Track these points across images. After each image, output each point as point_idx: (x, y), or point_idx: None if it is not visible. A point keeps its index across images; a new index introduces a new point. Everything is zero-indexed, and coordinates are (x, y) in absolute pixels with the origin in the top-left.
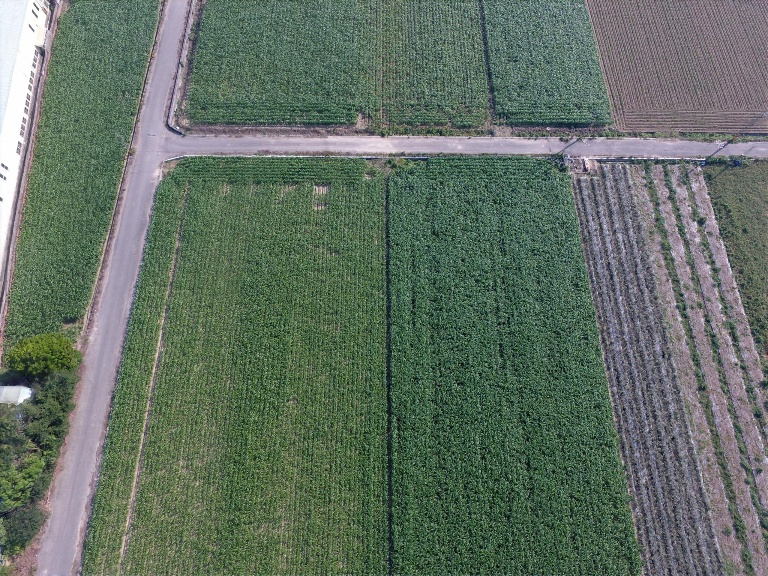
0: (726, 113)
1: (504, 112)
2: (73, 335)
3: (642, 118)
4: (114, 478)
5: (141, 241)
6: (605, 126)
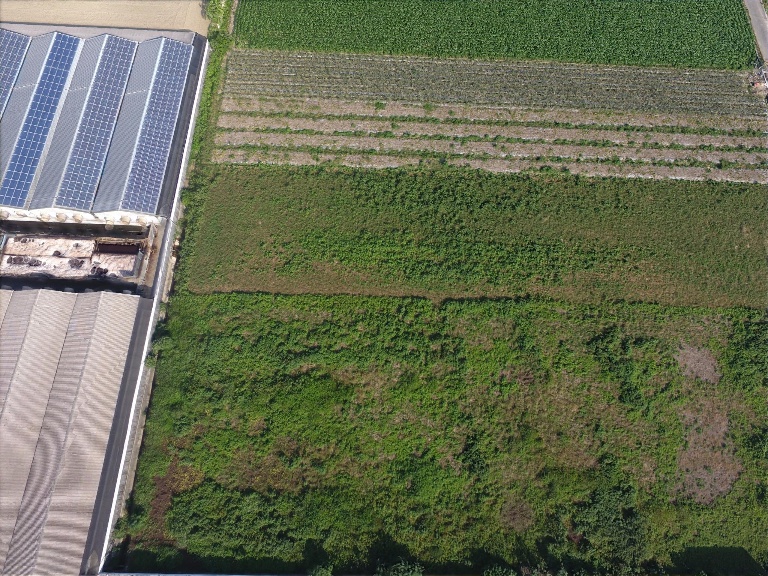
0: None
1: None
2: None
3: None
4: None
5: None
6: None
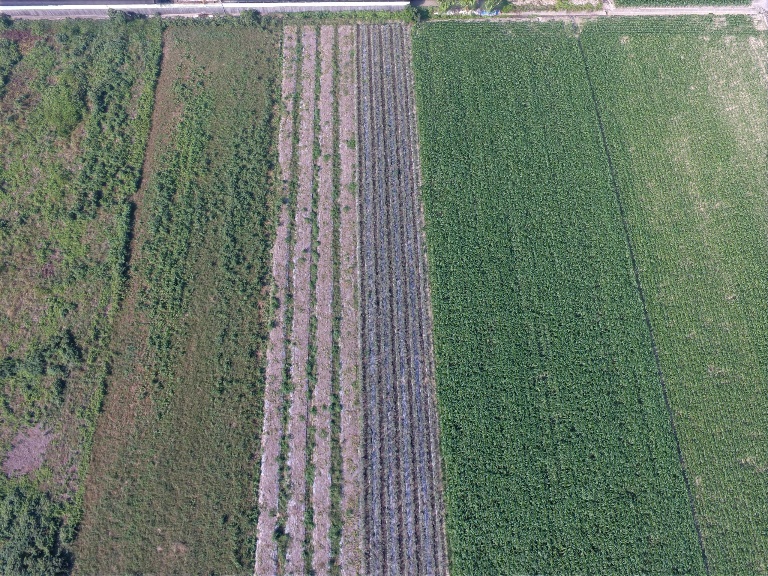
0: None
1: None
2: None
3: None
4: None
5: None
6: None
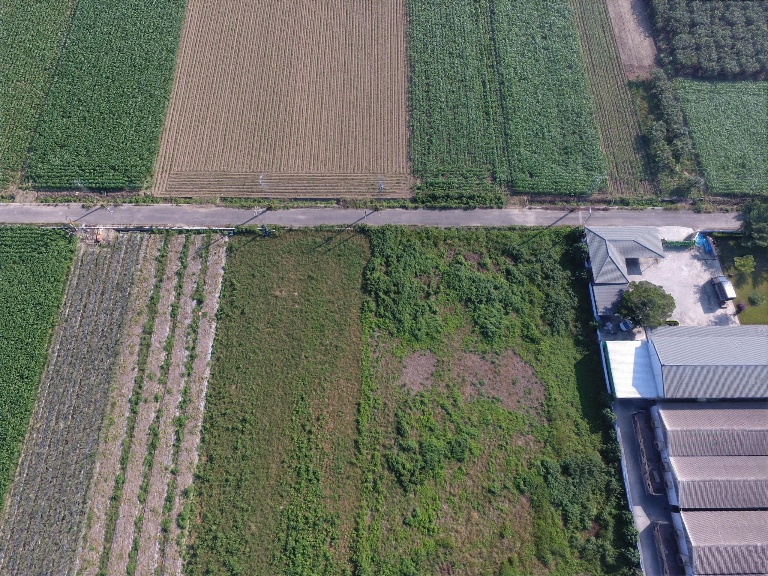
0: (282, 175)
1: (31, 175)
2: None
3: (187, 181)
4: None
5: None
6: (141, 190)
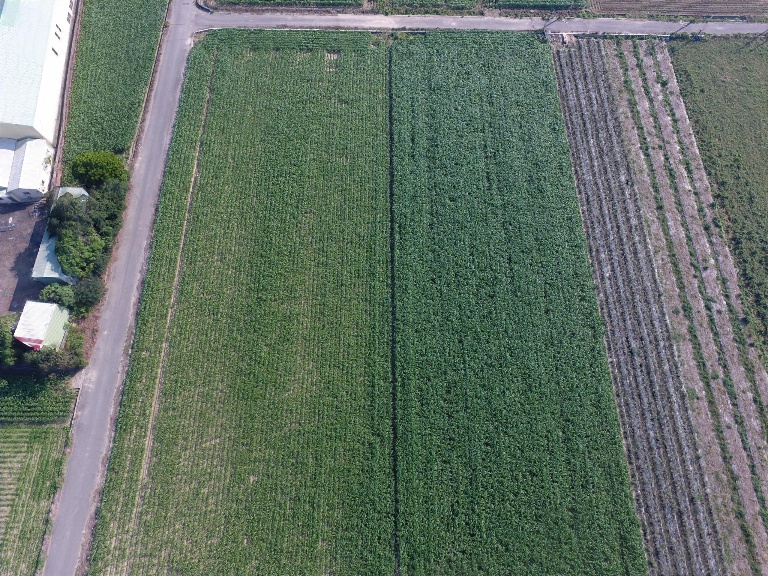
0: None
1: None
2: (121, 161)
3: (615, 3)
4: (160, 266)
5: (177, 93)
6: (582, 9)
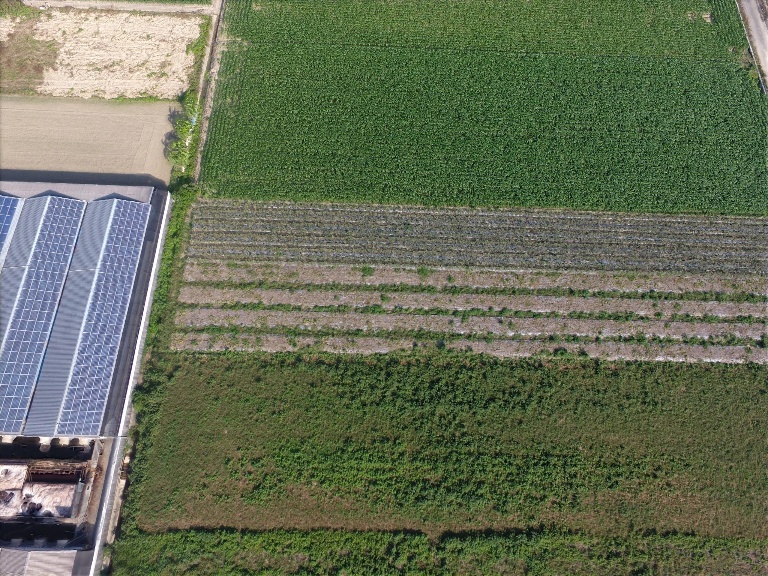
0: None
1: None
2: None
3: None
4: None
5: None
6: None
